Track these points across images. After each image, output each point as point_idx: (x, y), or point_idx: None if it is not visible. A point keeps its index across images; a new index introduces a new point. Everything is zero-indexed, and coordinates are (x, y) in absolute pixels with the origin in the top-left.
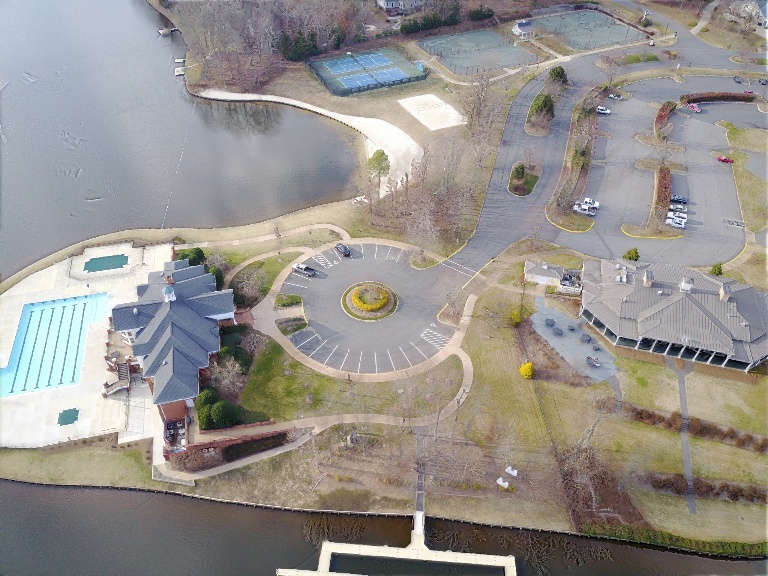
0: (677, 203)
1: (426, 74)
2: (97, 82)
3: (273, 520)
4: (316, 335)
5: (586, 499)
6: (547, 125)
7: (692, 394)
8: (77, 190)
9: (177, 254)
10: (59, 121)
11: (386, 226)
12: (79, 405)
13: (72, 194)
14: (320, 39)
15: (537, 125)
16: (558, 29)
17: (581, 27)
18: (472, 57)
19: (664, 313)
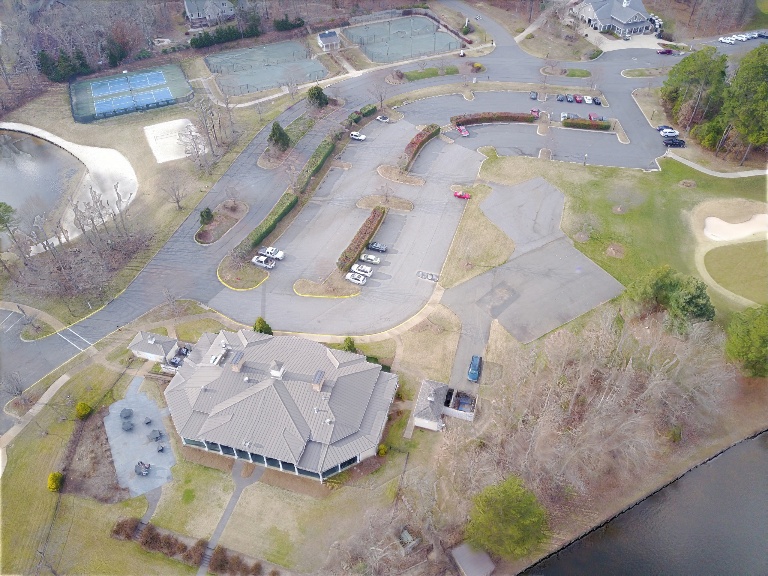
0: (375, 251)
1: (188, 95)
2: None
3: None
4: None
5: None
6: (285, 155)
7: (239, 513)
8: None
9: None
10: None
11: (31, 284)
12: None
13: None
14: (90, 57)
15: (272, 155)
16: (366, 39)
17: (397, 36)
18: (255, 74)
19: (240, 406)
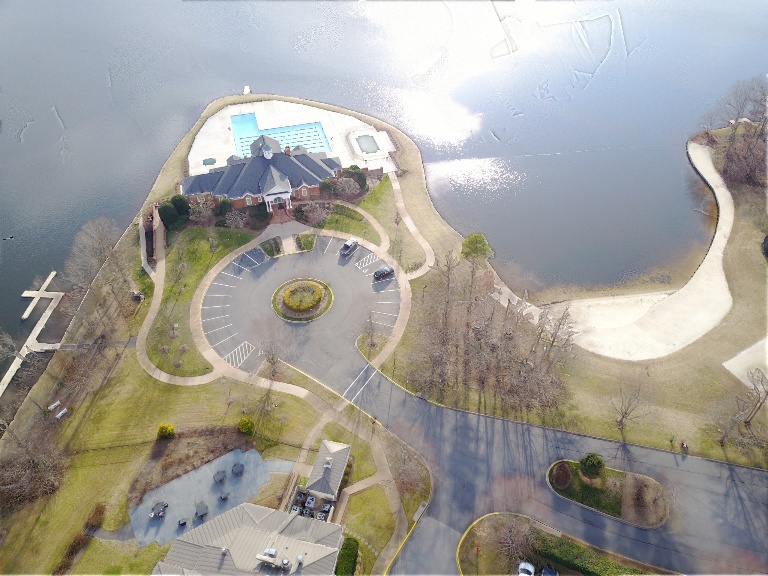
0: None
1: None
2: (667, 80)
3: (96, 267)
4: (258, 264)
5: (7, 479)
6: None
7: None
8: (499, 123)
9: (381, 175)
10: (548, 70)
11: None
12: (218, 163)
13: (492, 122)
14: None
15: None
16: None
17: None
18: None
19: None
